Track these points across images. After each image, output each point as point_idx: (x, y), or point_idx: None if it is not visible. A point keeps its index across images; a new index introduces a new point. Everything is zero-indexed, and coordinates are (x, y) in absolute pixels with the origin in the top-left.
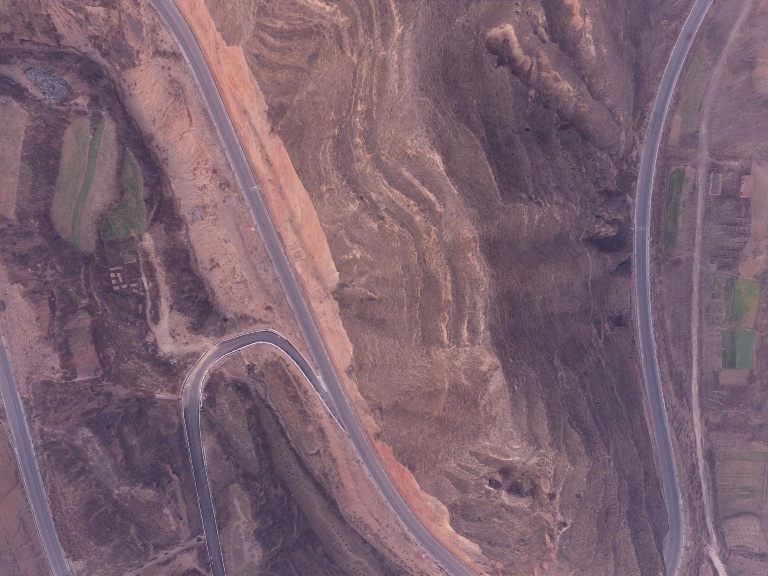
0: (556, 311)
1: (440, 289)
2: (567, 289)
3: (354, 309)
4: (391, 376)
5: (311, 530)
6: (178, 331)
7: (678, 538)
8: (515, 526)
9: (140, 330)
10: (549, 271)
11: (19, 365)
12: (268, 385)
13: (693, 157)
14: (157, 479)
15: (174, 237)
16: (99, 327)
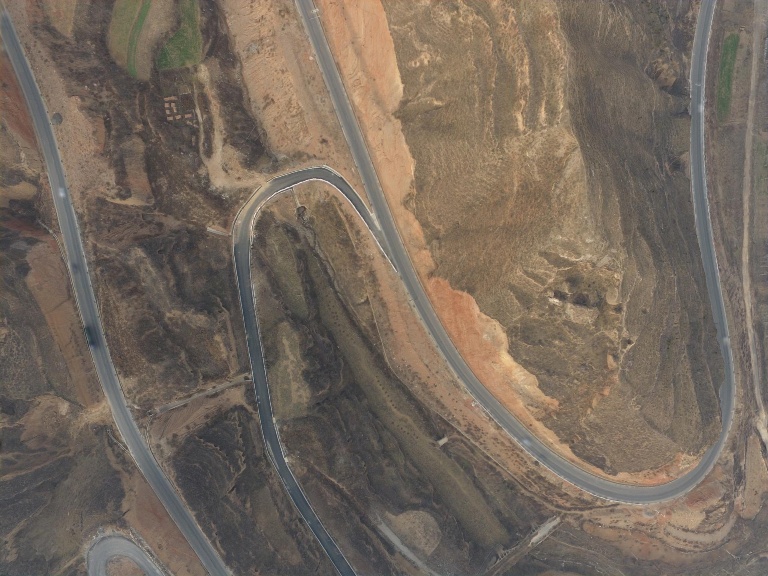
0: (624, 126)
1: (515, 78)
2: (634, 109)
3: (419, 121)
4: (456, 186)
5: (356, 384)
6: (231, 165)
7: (729, 400)
8: (577, 348)
9: (193, 162)
10: (620, 80)
11: (74, 179)
12: (318, 230)
13: (750, 17)
14: (208, 307)
15: (228, 74)
16: (152, 155)
